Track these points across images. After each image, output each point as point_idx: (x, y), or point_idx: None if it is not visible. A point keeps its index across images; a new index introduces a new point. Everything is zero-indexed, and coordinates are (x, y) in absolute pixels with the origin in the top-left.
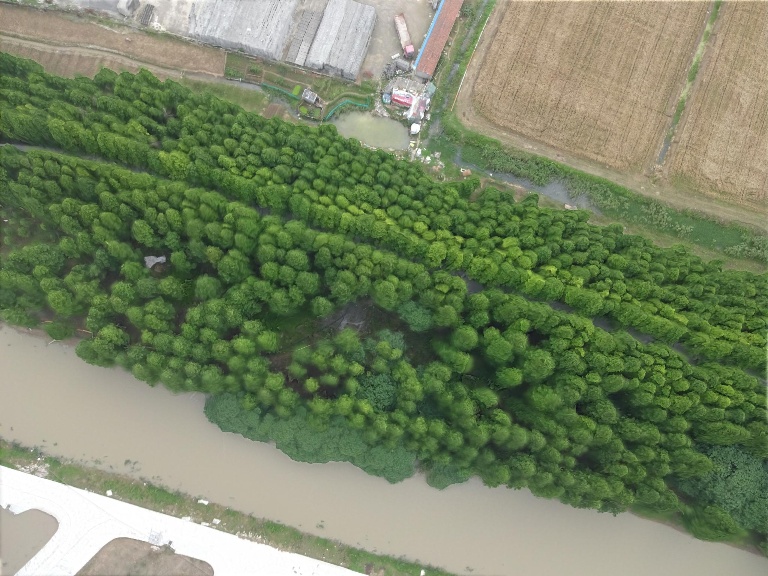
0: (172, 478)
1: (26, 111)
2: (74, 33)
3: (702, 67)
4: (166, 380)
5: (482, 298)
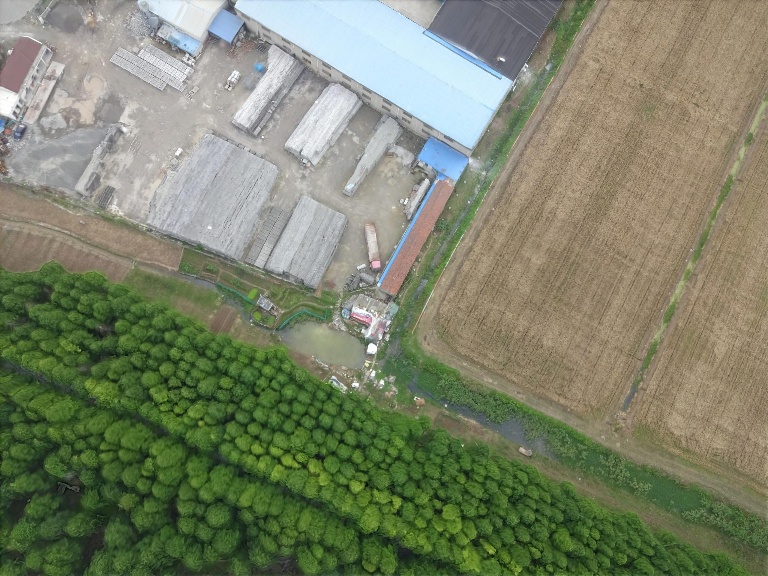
0: None
1: None
2: (26, 208)
3: (679, 309)
4: None
5: None
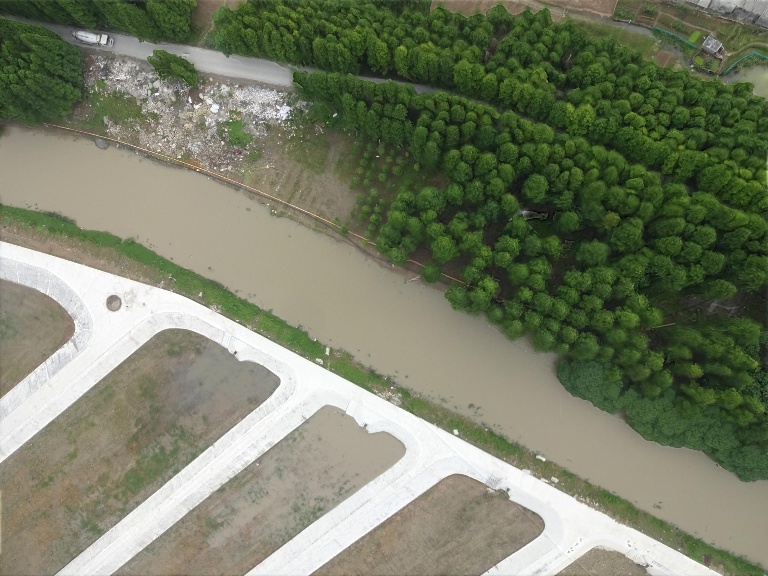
0: (512, 429)
1: (430, 50)
2: None
3: None
4: (543, 341)
5: None
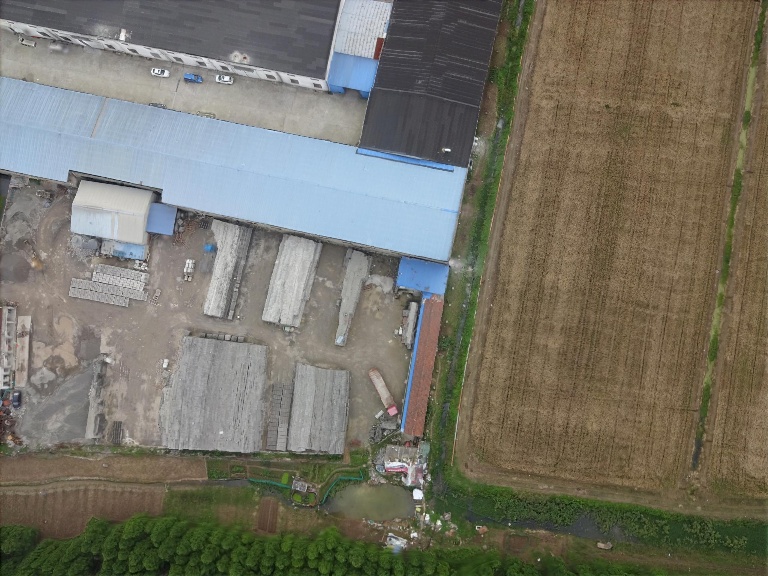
0: None
1: None
2: (51, 469)
3: (722, 342)
4: None
5: None
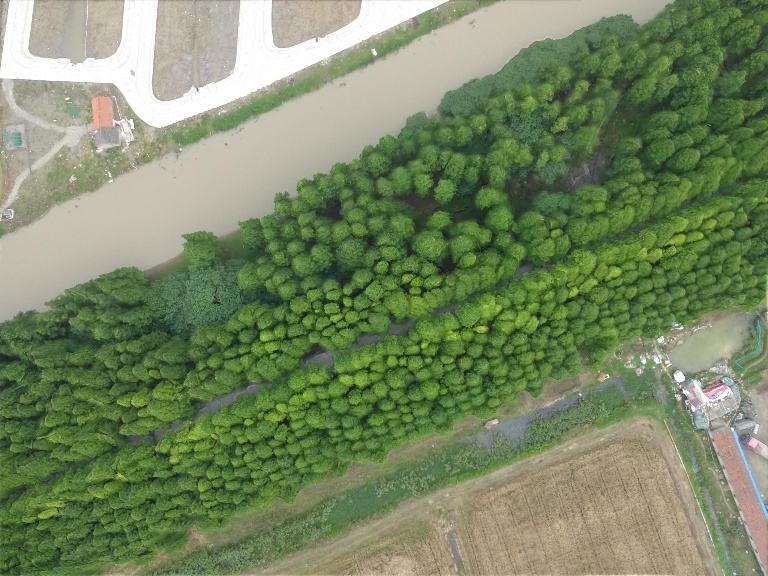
0: None
1: None
2: None
3: None
4: None
5: (518, 255)
